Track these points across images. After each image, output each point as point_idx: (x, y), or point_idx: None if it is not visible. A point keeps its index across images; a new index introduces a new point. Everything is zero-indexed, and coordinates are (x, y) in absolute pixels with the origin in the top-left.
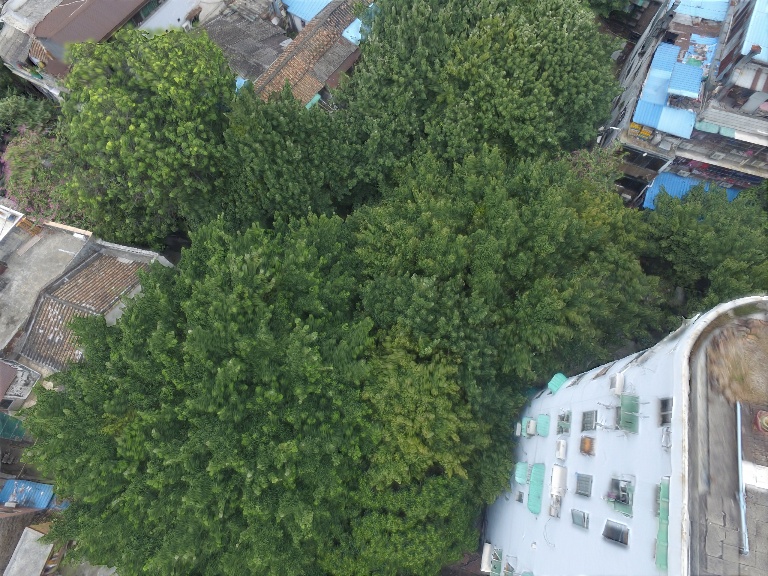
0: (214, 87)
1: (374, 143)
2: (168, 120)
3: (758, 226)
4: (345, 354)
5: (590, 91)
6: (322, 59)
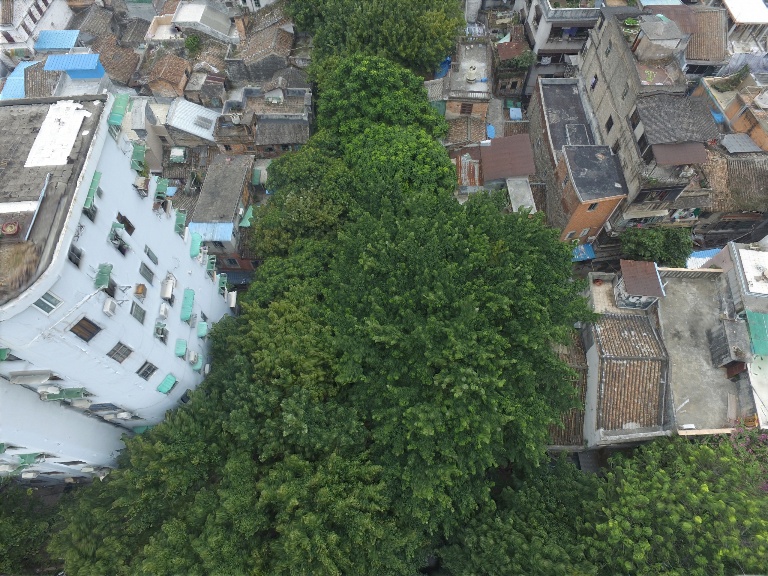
0: None
1: None
2: (680, 568)
3: None
4: None
5: None
6: None
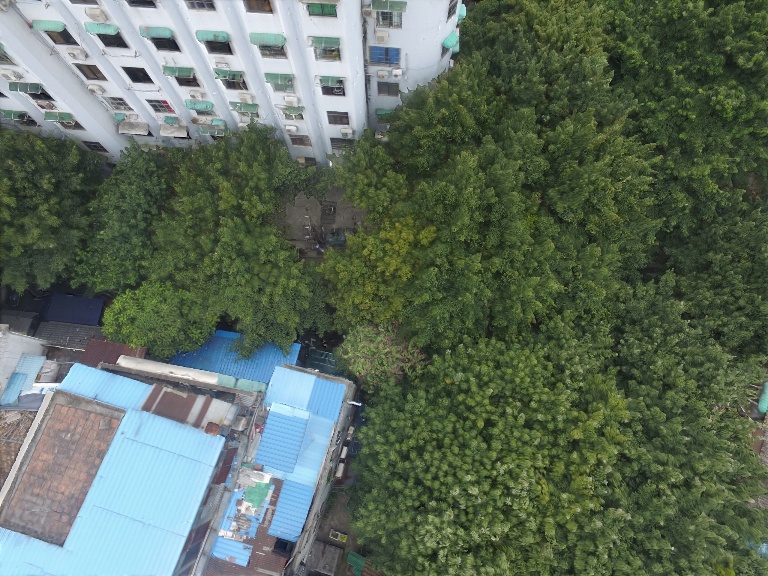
0: None
1: None
2: None
3: (197, 293)
4: None
5: (409, 418)
6: None
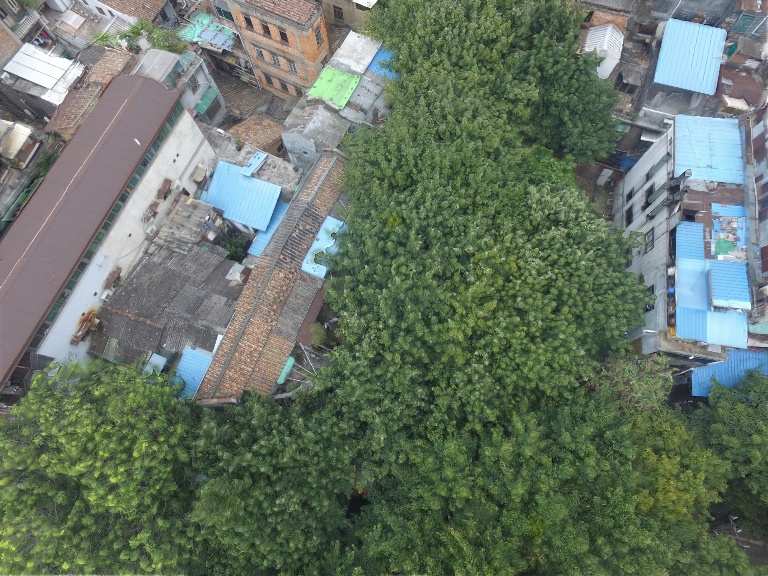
0: (165, 455)
1: None
2: None
3: None
4: None
5: (620, 312)
6: (285, 309)
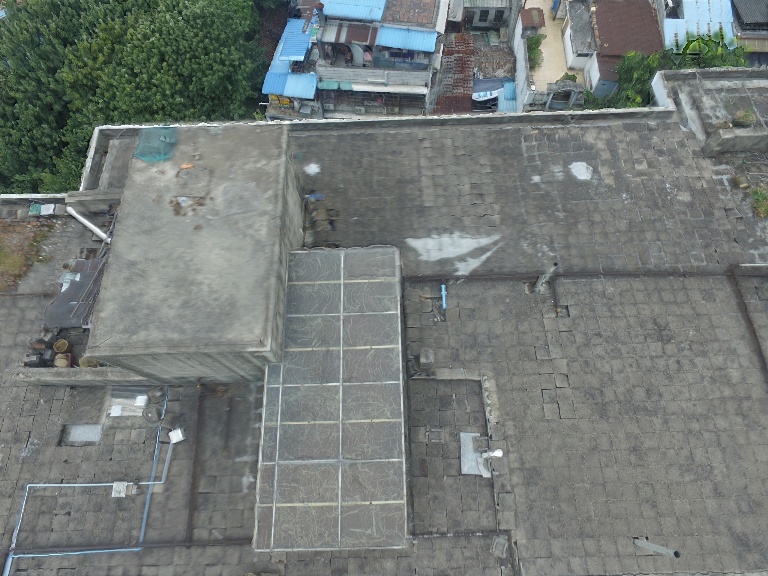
0: None
1: (6, 161)
2: None
3: None
4: None
5: (216, 73)
6: None
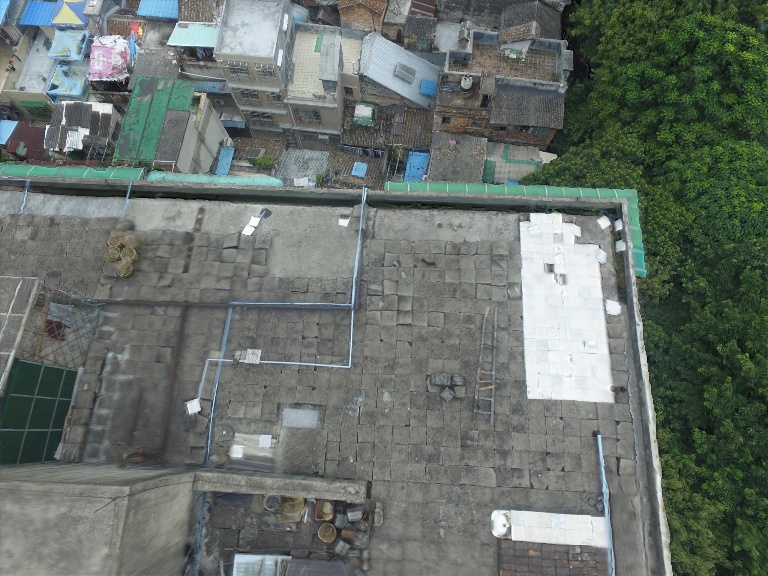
0: None
1: None
2: None
3: None
4: (767, 557)
5: None
6: None
